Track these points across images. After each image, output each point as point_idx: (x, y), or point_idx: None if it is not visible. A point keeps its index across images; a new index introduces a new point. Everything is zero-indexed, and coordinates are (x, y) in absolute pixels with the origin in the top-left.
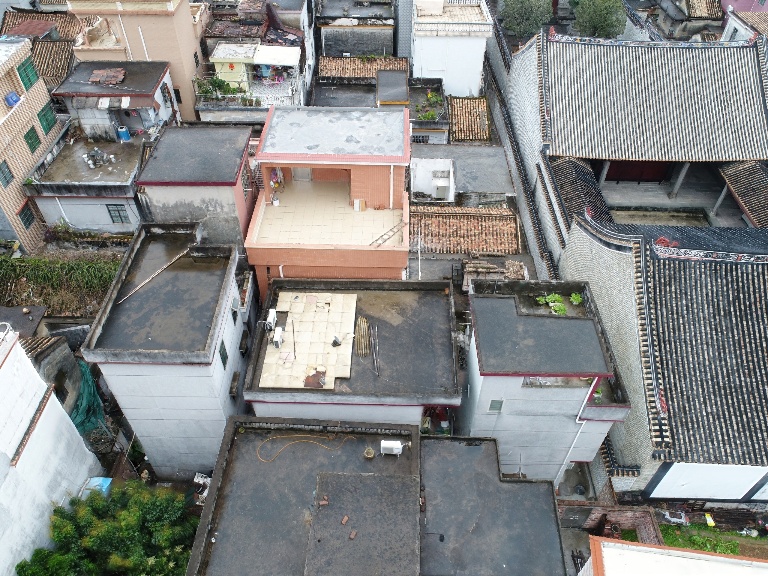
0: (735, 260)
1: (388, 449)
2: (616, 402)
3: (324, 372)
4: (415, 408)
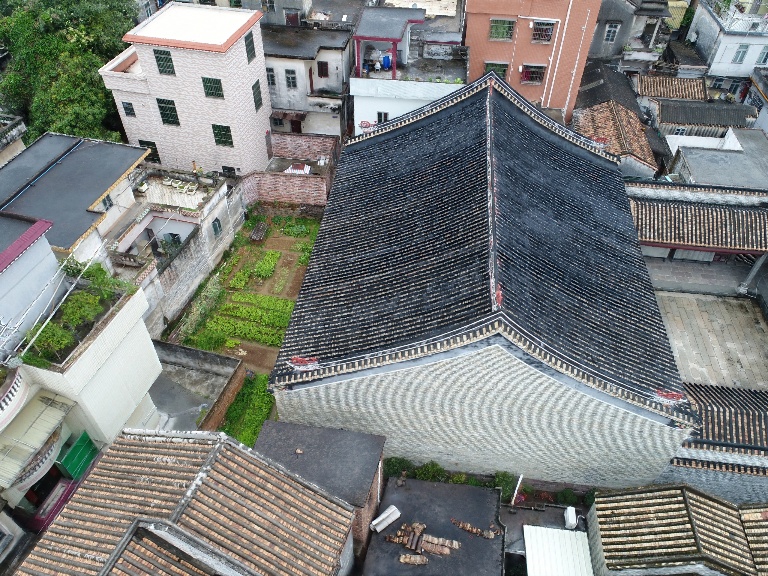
0: None
1: None
2: None
3: (394, 6)
4: None
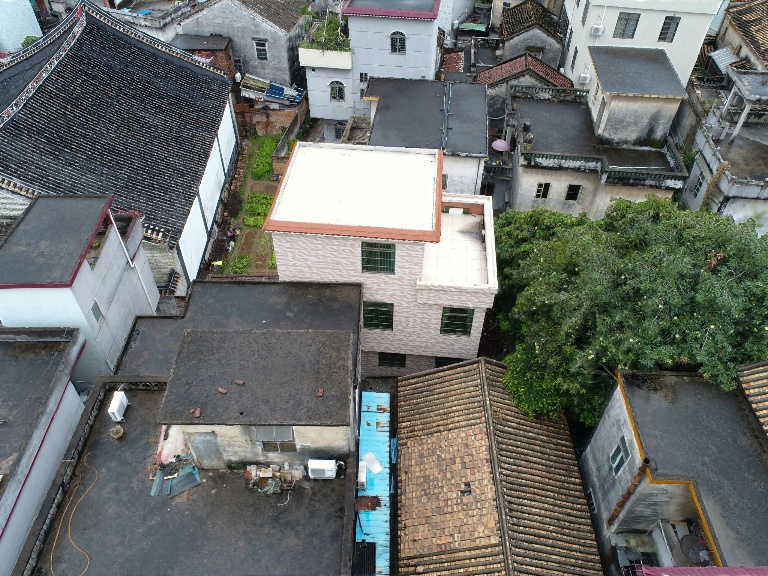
0: (8, 118)
1: (120, 407)
2: (124, 232)
3: None
4: (68, 391)
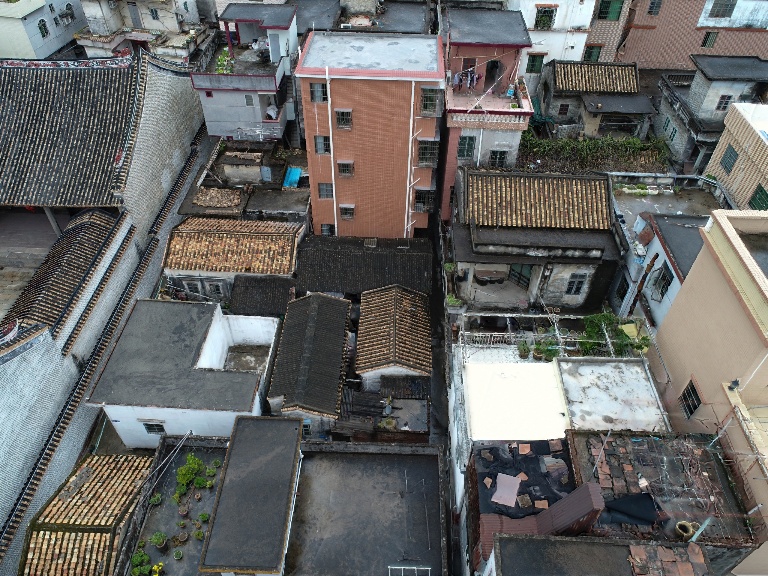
0: None
1: None
2: (218, 46)
3: None
4: None
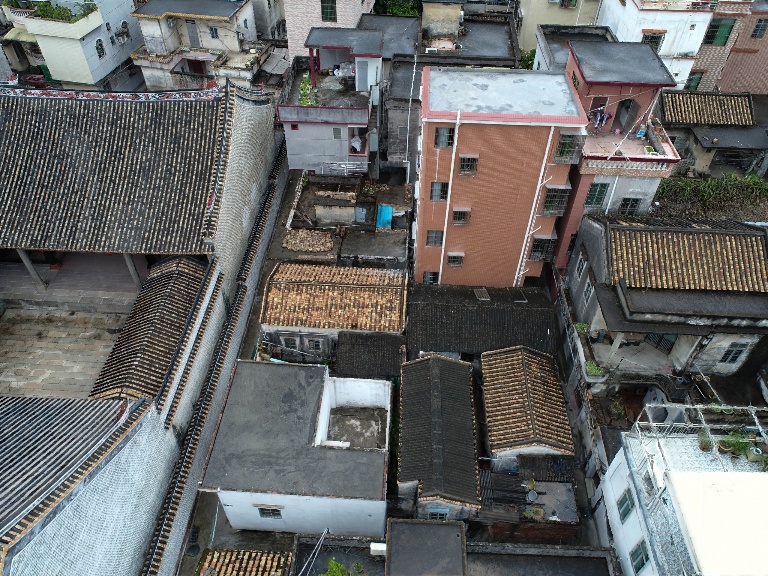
0: None
1: None
2: None
3: None
4: None
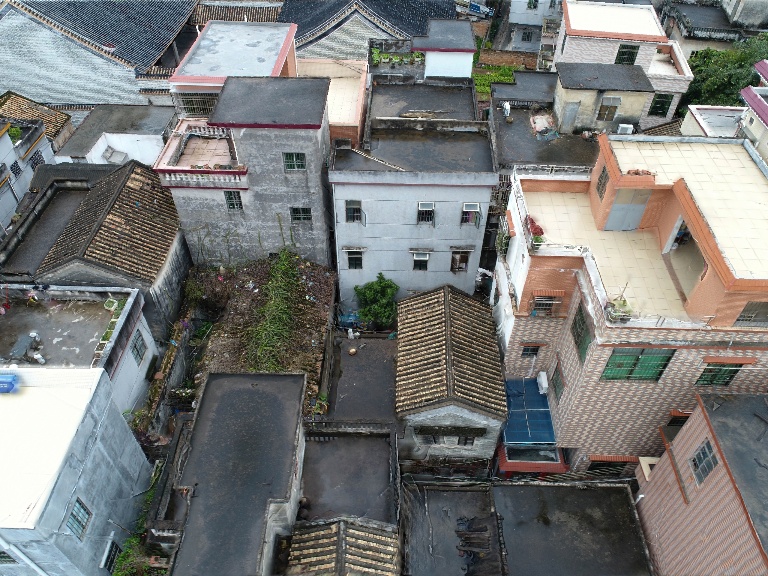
0: None
1: None
2: None
3: None
4: None
